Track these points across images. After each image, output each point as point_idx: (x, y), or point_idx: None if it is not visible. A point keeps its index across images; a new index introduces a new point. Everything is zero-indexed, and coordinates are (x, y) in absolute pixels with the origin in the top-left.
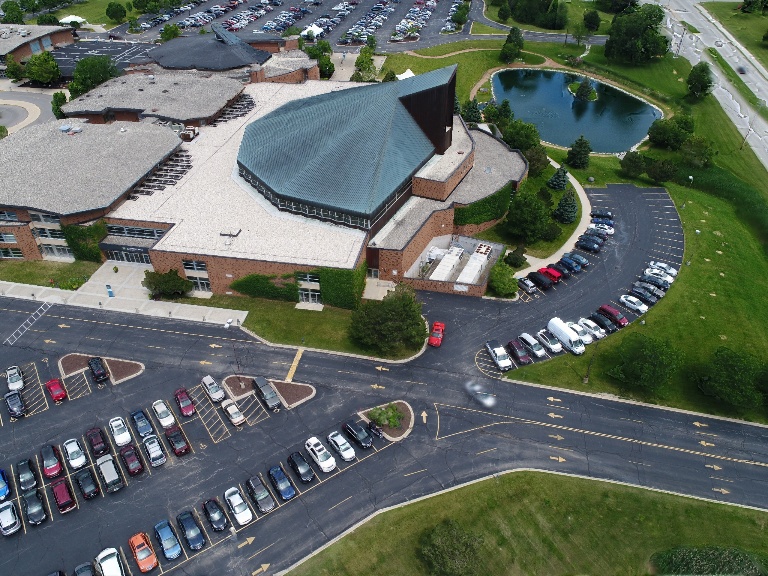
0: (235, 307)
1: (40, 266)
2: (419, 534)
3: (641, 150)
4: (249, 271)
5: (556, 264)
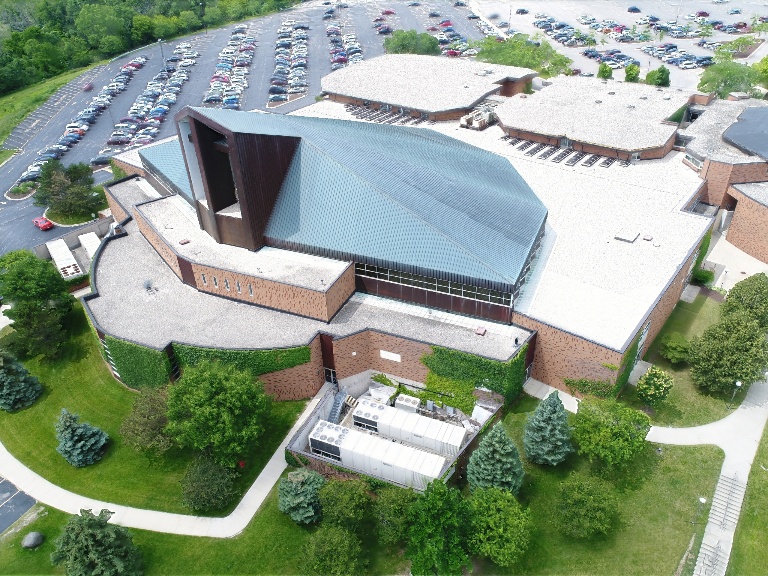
0: None
1: None
2: None
3: None
4: None
5: None
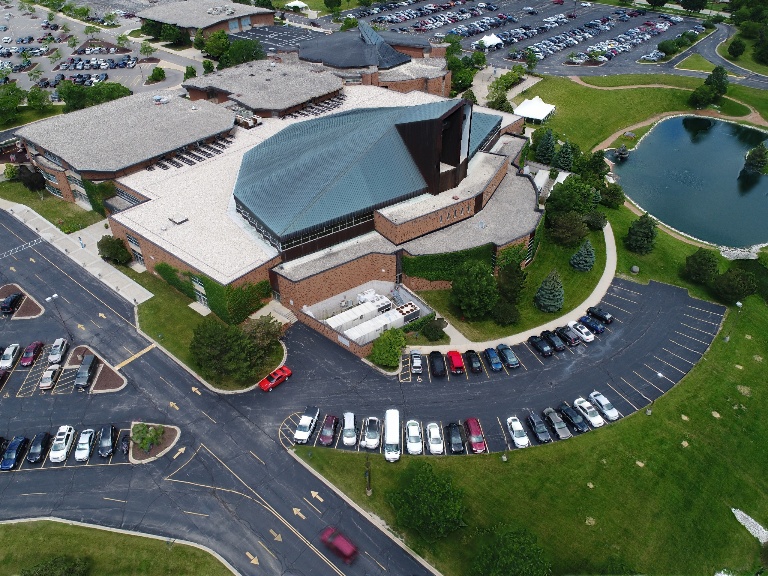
0: (149, 287)
1: (68, 207)
2: (55, 557)
3: (765, 252)
4: (162, 259)
5: (481, 353)
